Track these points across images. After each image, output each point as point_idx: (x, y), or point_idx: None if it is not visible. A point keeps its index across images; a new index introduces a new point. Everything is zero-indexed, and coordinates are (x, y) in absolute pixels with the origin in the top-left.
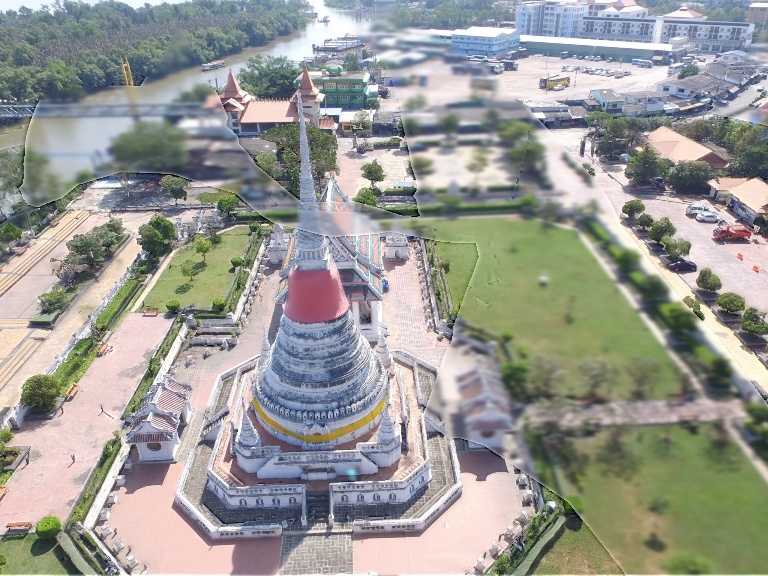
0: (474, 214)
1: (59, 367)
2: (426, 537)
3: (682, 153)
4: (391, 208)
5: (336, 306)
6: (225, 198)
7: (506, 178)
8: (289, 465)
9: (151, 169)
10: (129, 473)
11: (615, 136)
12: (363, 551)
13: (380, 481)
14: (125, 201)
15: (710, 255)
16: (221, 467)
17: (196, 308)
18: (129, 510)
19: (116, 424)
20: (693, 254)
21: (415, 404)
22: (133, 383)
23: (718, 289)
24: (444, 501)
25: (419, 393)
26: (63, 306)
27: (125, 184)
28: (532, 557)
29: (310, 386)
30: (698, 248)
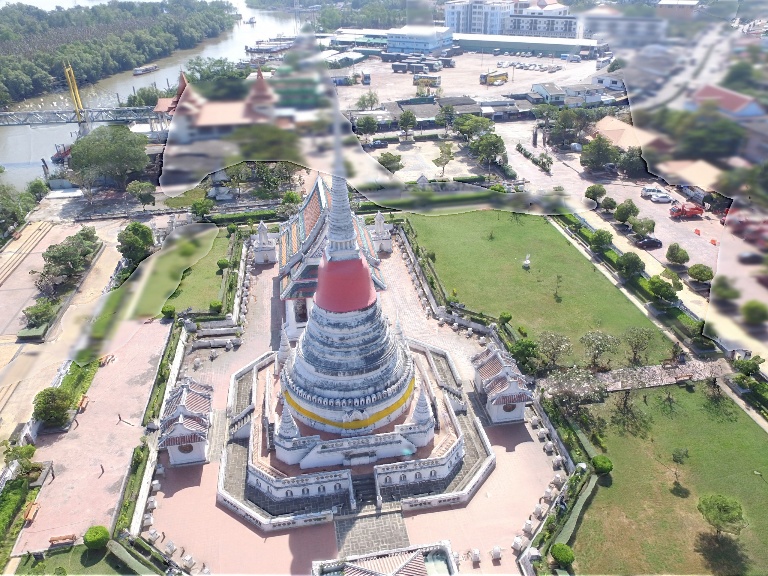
0: (716, 166)
1: (64, 380)
2: (472, 508)
3: (630, 140)
4: (366, 204)
5: (367, 294)
6: (199, 201)
7: (767, 131)
8: (332, 452)
9: (271, 157)
10: (163, 478)
11: (566, 126)
12: (416, 527)
13: (422, 459)
14: (87, 210)
15: (671, 232)
16: (260, 462)
17: (193, 311)
18: (172, 513)
19: (138, 431)
20: (656, 232)
21: (435, 386)
22: (145, 390)
23: (687, 262)
24: (482, 473)
25: (438, 375)
26: (50, 319)
27: (87, 192)
28: (576, 514)
29: (347, 374)
30: (659, 226)
